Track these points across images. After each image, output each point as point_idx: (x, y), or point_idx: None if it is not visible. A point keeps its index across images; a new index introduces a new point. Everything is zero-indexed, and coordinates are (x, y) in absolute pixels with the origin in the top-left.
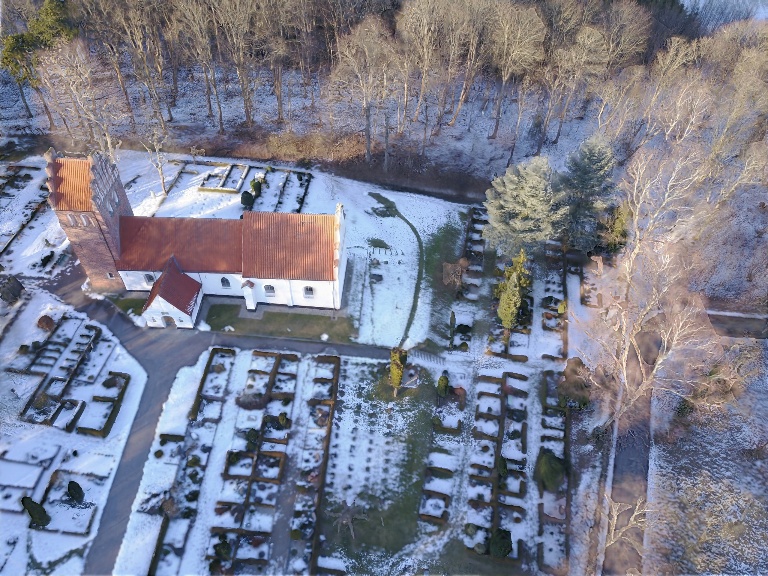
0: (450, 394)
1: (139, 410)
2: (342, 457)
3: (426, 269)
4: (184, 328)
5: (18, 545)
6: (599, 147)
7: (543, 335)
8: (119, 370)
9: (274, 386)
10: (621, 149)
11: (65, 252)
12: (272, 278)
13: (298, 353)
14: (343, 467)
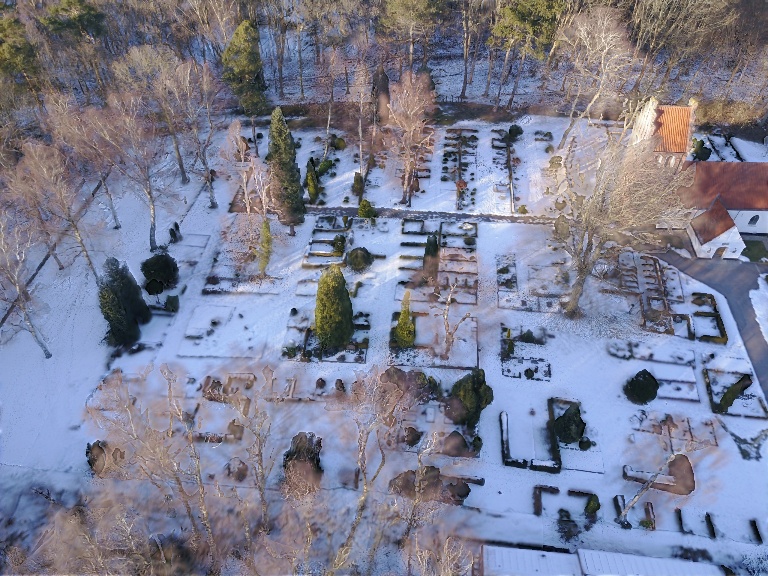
0: None
1: (738, 324)
2: None
3: None
4: (729, 259)
5: (715, 426)
6: None
7: None
8: None
9: None
10: None
11: None
12: None
13: None
14: None
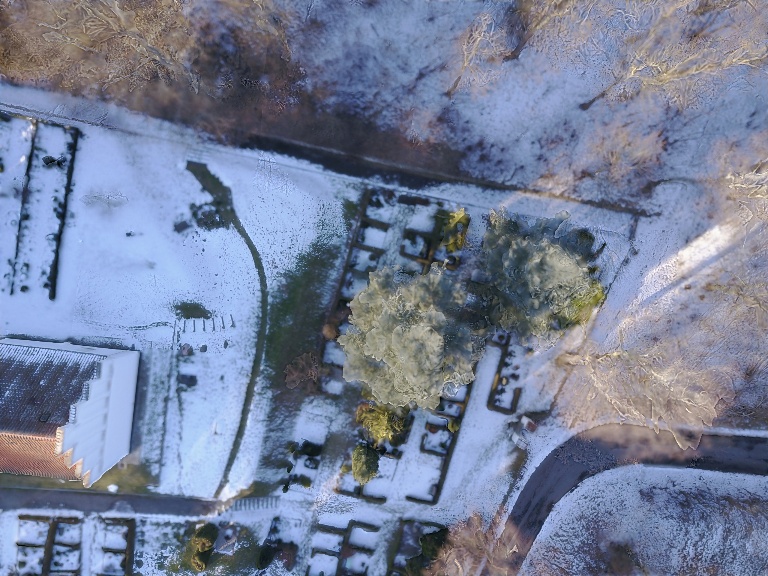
0: (277, 551)
1: None
2: None
3: (267, 353)
4: None
5: None
6: (562, 285)
7: (417, 461)
8: None
9: (52, 561)
10: (685, 31)
11: None
12: None
13: (79, 513)
14: None
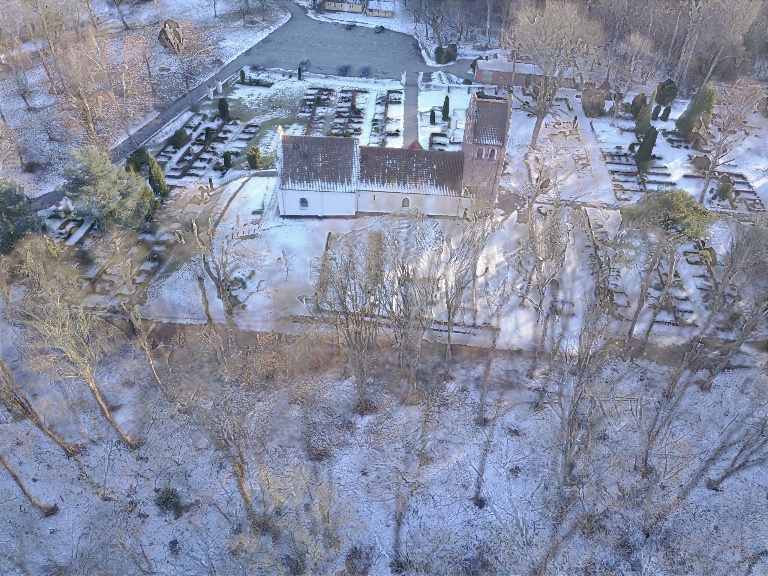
0: None
1: None
2: None
3: None
4: None
5: (452, 114)
6: None
7: None
8: None
9: None
10: None
11: None
12: None
13: None
14: None
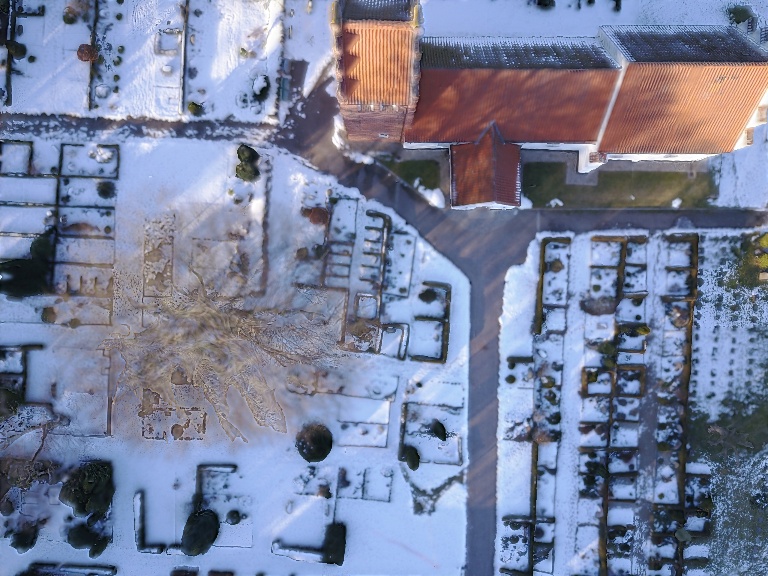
0: None
1: (473, 328)
2: (704, 362)
3: None
4: (500, 209)
5: (395, 477)
6: None
7: None
8: (433, 276)
9: (624, 283)
10: None
11: (281, 73)
12: (643, 153)
13: (646, 231)
14: (706, 373)
